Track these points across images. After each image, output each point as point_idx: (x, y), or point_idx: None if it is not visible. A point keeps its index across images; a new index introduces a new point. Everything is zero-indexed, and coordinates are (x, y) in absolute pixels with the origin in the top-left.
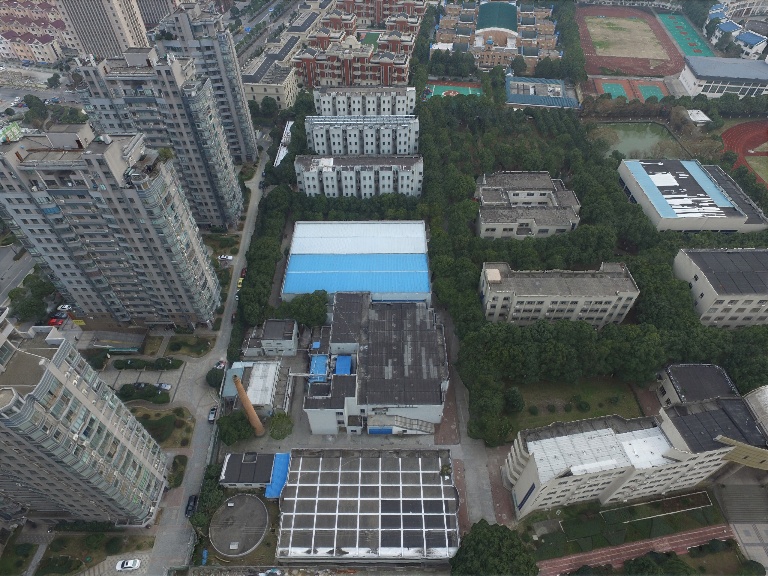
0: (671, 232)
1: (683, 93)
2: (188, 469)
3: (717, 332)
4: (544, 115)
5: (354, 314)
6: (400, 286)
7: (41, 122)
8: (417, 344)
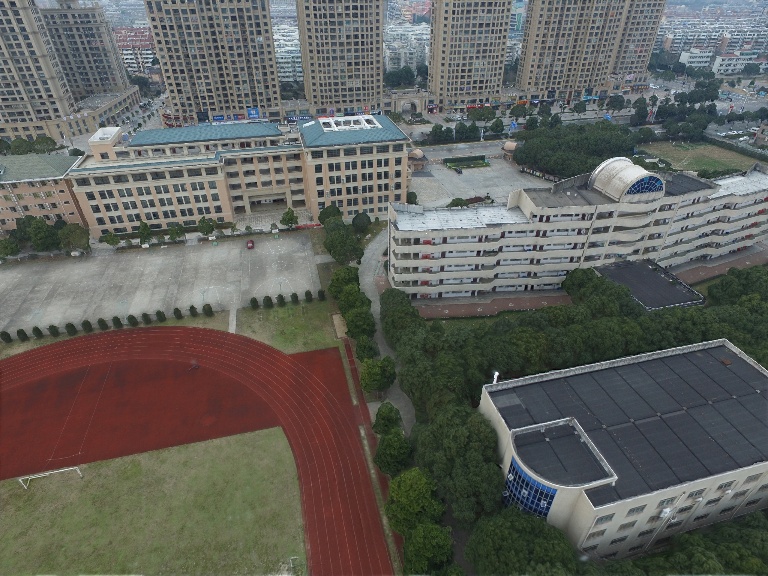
0: None
1: None
2: None
3: (683, 319)
4: None
5: None
6: None
7: None
8: None
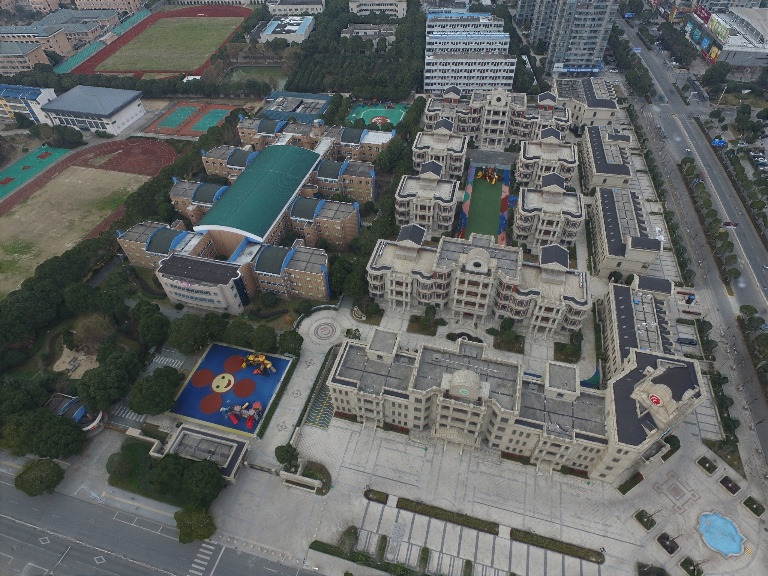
0: (314, 15)
1: (146, 118)
2: (502, 3)
3: None
4: (313, 82)
5: (458, 6)
6: (440, 15)
7: (762, 75)
8: (434, 2)
